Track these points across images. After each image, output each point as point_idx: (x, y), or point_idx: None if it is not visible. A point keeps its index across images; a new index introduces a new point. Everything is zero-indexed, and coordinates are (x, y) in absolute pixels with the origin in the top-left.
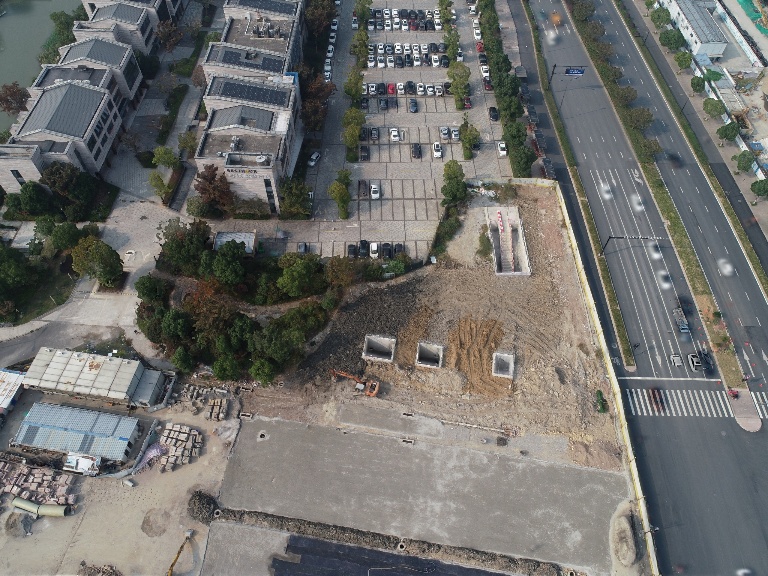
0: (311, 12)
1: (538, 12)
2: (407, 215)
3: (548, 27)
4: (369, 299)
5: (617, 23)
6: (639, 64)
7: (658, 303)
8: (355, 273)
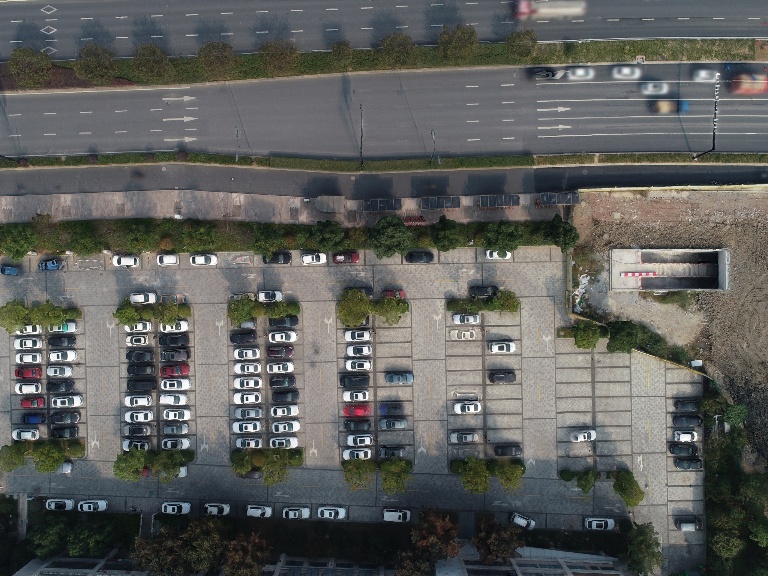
0: (245, 570)
1: (124, 142)
2: (622, 393)
3: (173, 132)
4: (761, 442)
5: (160, 7)
6: (285, 1)
7: (763, 106)
8: (727, 460)
